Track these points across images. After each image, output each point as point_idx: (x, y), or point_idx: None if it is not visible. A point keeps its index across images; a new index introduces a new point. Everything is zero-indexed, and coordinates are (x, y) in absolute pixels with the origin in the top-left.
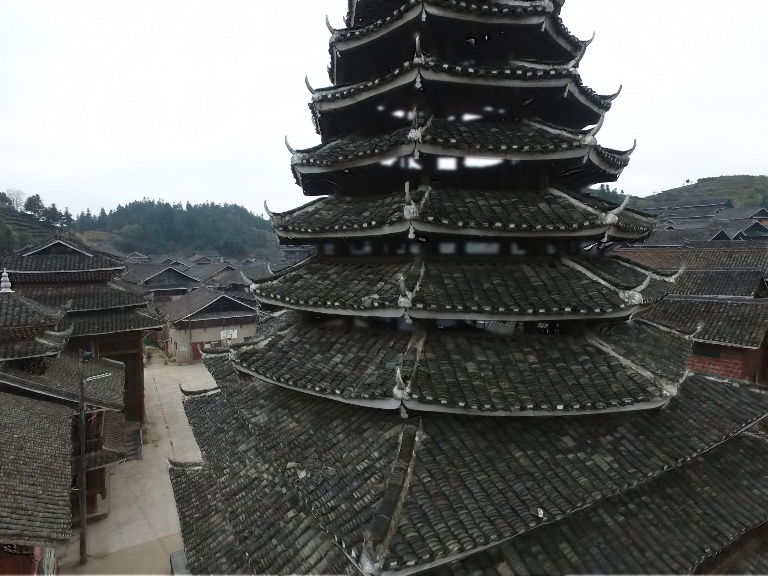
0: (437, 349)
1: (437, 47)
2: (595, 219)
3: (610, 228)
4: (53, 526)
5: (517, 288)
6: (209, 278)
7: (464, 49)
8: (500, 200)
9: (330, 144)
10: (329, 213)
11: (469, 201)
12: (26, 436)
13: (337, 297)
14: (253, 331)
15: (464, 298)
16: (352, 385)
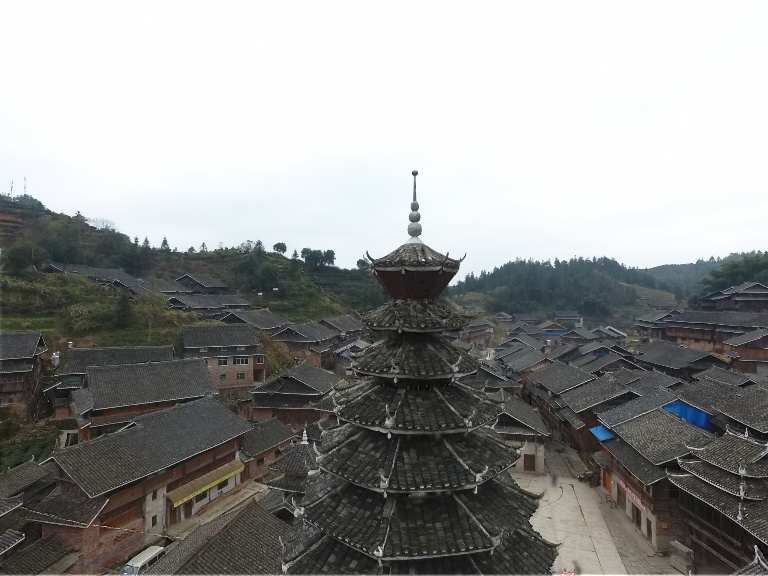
0: None
1: None
2: None
3: None
4: None
5: None
6: (527, 369)
7: None
8: None
9: None
10: None
11: None
12: (265, 568)
13: None
14: (533, 450)
15: None
16: None
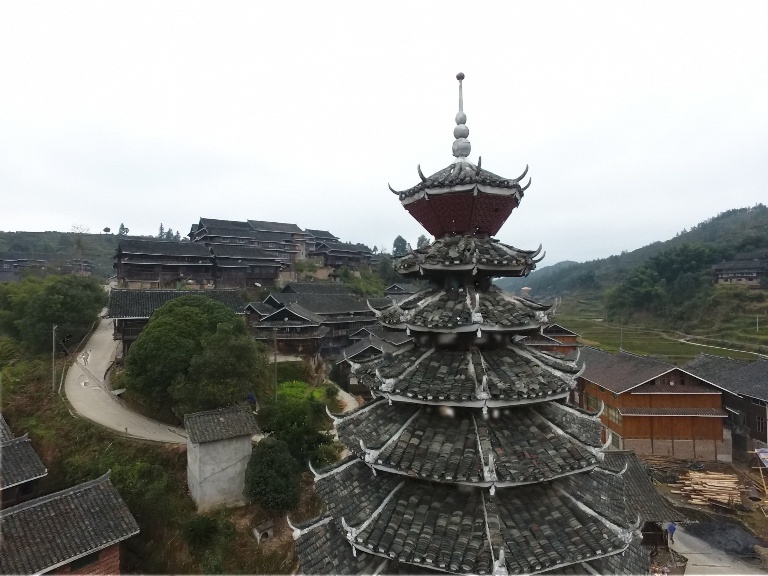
0: None
1: None
2: None
3: None
4: None
5: None
6: None
7: None
8: None
9: None
10: None
11: None
12: None
13: None
14: None
15: None
16: None
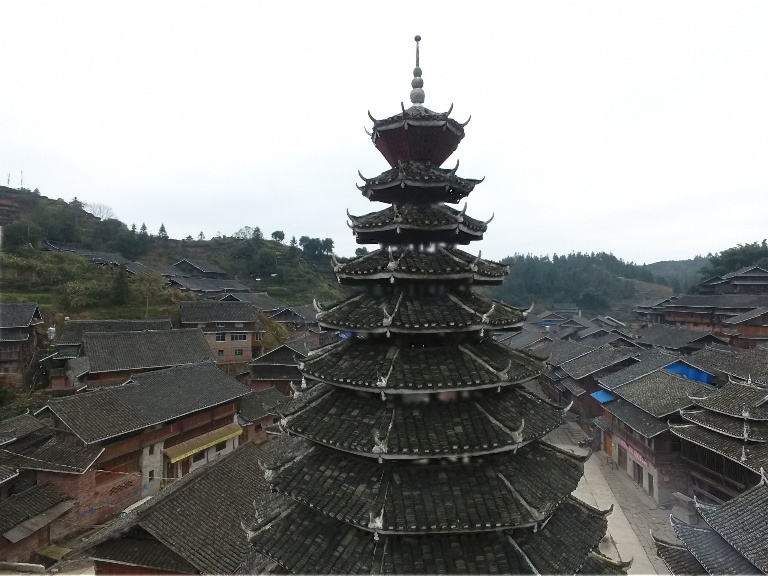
0: (281, 573)
1: (349, 335)
2: (363, 519)
3: (377, 530)
4: (224, 569)
5: (321, 552)
6: (526, 348)
7: (360, 339)
8: (342, 472)
9: (317, 385)
10: (298, 439)
11: (320, 469)
12: None
13: (264, 508)
14: None
15: (283, 547)
16: (242, 574)
